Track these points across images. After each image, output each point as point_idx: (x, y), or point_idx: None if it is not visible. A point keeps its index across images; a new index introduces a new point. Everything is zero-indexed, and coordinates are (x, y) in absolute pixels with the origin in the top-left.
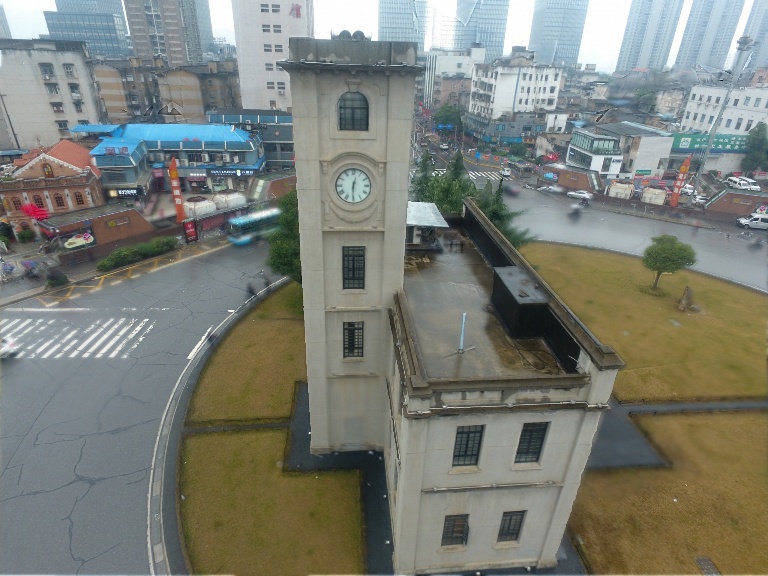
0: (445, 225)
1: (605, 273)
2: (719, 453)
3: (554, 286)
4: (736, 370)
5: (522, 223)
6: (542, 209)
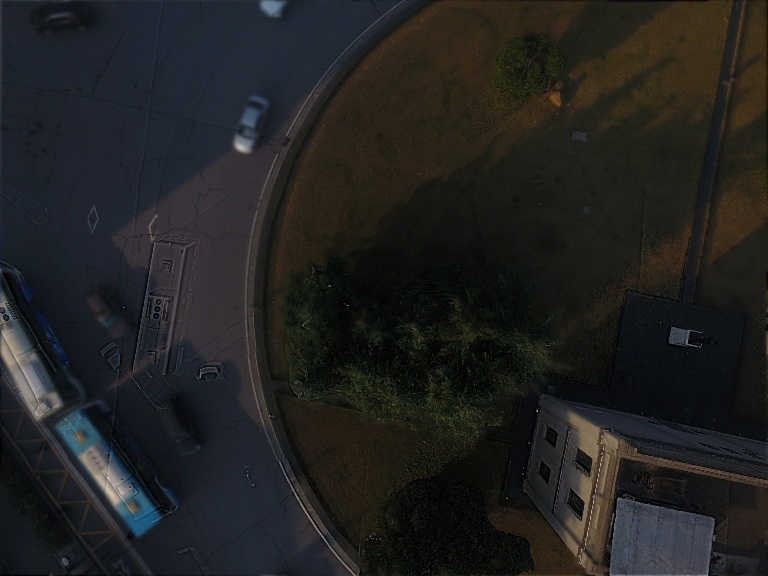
0: (710, 523)
1: (447, 120)
2: (746, 268)
3: (468, 218)
4: (667, 154)
5: (211, 104)
6: (145, 17)
